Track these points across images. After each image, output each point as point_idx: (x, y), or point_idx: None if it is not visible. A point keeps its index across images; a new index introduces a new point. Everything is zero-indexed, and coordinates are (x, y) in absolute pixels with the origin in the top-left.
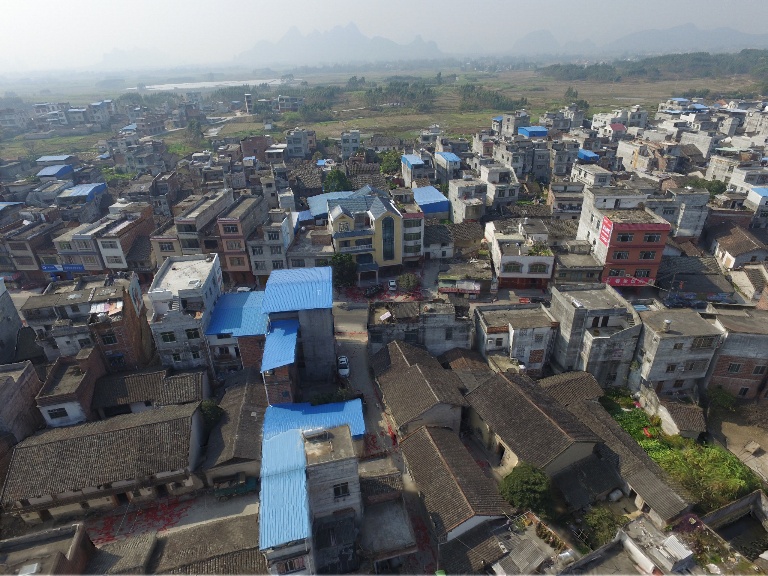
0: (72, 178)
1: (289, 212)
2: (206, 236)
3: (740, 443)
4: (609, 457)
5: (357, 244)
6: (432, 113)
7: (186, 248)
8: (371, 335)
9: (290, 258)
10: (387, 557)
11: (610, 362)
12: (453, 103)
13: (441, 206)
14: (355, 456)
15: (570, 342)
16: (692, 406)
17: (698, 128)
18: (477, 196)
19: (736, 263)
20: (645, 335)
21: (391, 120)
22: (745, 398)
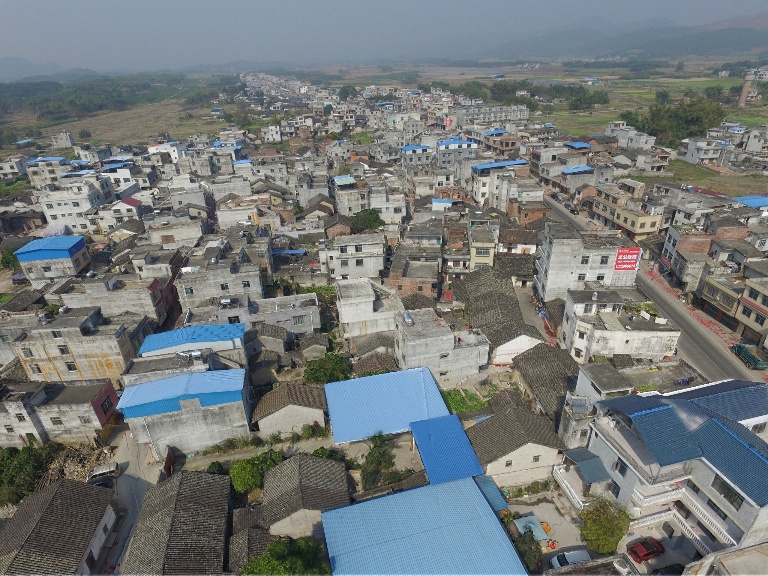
0: None
1: None
2: None
3: None
4: None
5: None
6: None
7: None
8: None
9: None
10: None
11: None
12: None
13: None
14: None
15: None
16: None
17: (146, 182)
18: None
19: None
20: None
21: None
22: None
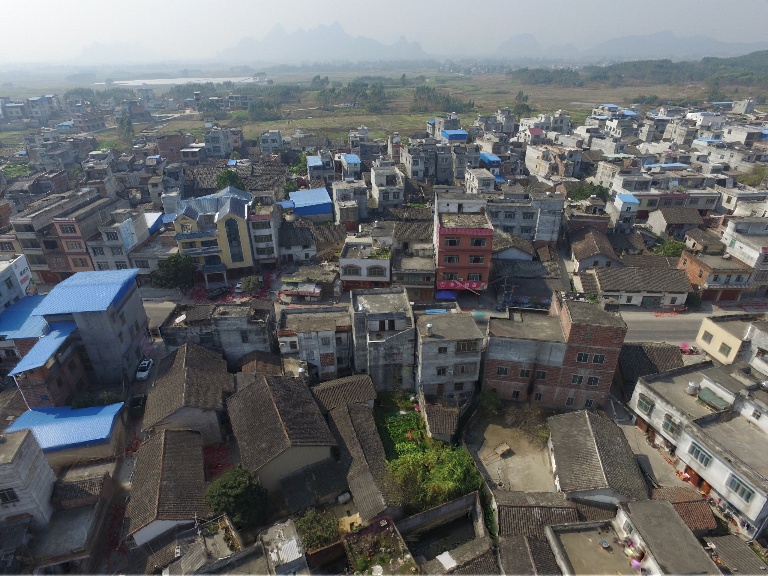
0: None
1: (139, 213)
2: (44, 236)
3: (495, 445)
4: (345, 460)
5: (203, 246)
6: (382, 114)
7: (27, 248)
8: (165, 338)
9: (133, 259)
10: (53, 563)
11: (392, 365)
12: (407, 105)
13: (324, 208)
14: (10, 462)
15: (357, 345)
16: (453, 409)
17: (619, 134)
18: (357, 198)
19: (580, 267)
20: (418, 339)
21: (338, 120)
22: (518, 401)
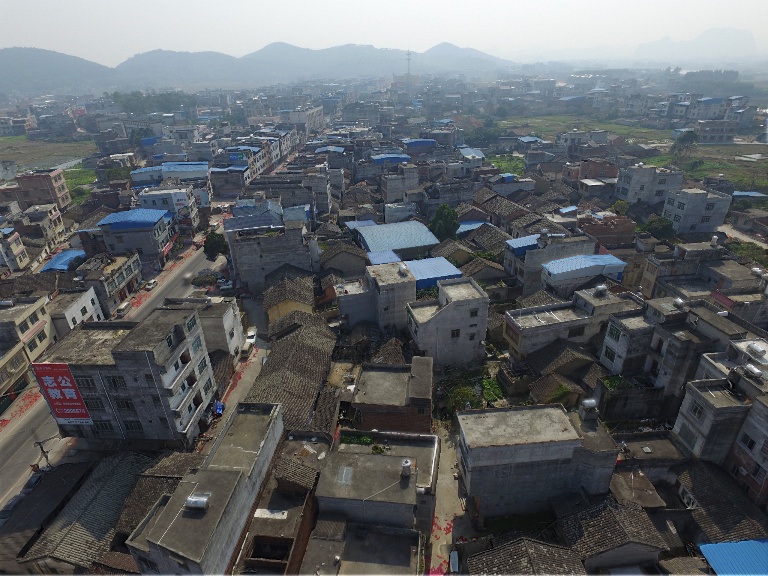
0: (428, 150)
1: (272, 200)
2: None
3: None
4: None
5: None
6: None
7: None
8: None
9: None
10: None
11: None
12: None
13: None
14: None
15: None
16: None
17: None
18: None
19: None
20: None
21: None
22: None
